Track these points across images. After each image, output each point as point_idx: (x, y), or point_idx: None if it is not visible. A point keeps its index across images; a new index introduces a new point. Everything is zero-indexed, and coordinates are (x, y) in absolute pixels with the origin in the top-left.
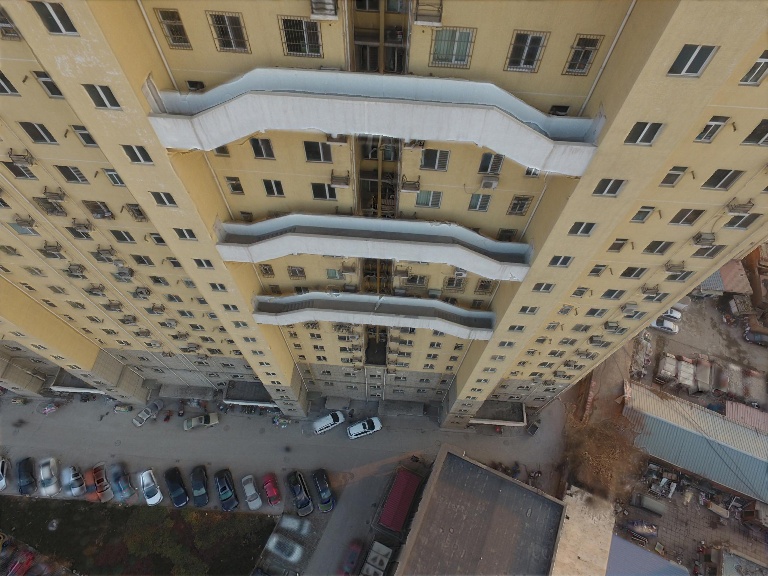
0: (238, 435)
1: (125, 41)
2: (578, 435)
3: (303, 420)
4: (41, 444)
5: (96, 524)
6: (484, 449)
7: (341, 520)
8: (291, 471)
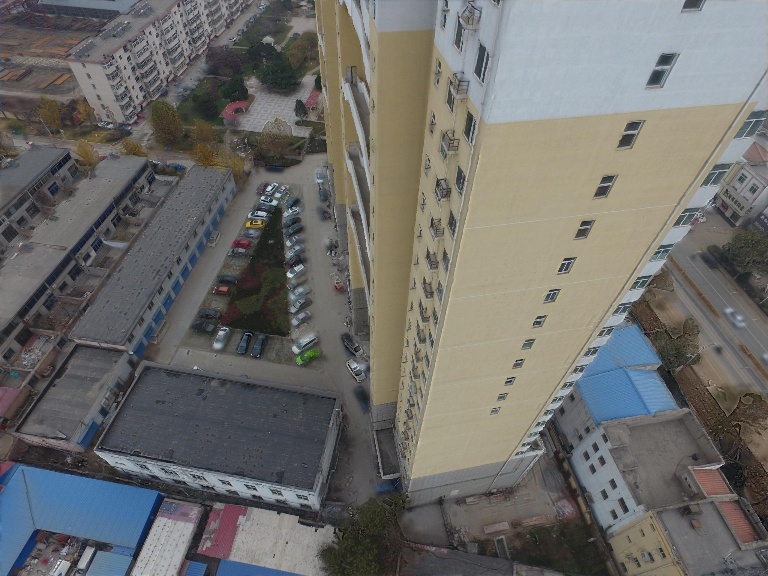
0: (334, 302)
1: (350, 50)
2: (373, 501)
3: (352, 333)
4: (309, 221)
5: (274, 257)
6: (362, 463)
7: (293, 372)
8: (318, 336)
